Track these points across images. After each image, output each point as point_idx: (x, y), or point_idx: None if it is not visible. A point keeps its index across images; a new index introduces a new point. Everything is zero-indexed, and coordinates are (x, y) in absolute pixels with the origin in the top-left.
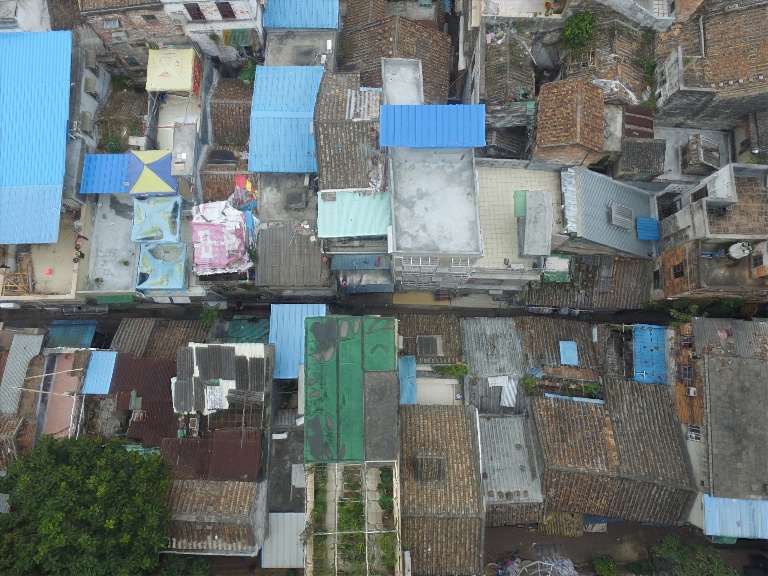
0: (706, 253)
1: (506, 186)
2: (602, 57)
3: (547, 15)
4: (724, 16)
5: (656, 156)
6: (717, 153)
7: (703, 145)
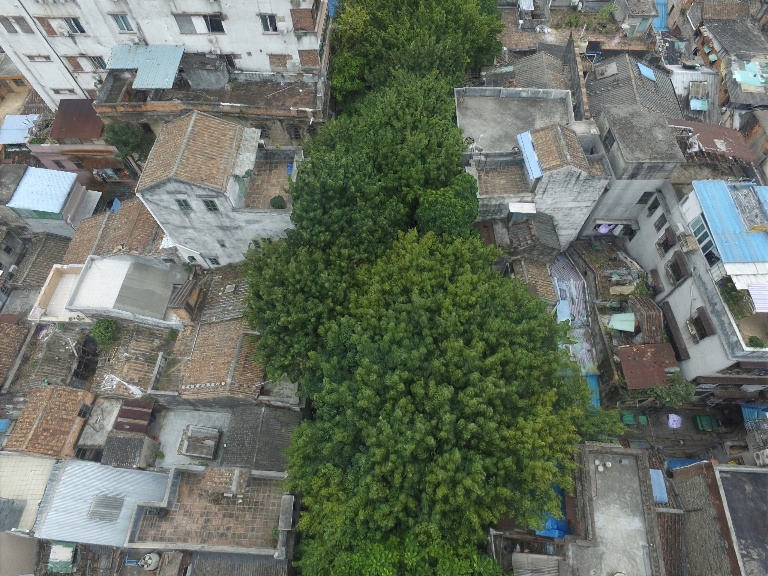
0: (132, 561)
1: (10, 475)
2: (120, 354)
3: (80, 320)
4: (209, 325)
5: (134, 450)
6: (212, 441)
7: (192, 435)
